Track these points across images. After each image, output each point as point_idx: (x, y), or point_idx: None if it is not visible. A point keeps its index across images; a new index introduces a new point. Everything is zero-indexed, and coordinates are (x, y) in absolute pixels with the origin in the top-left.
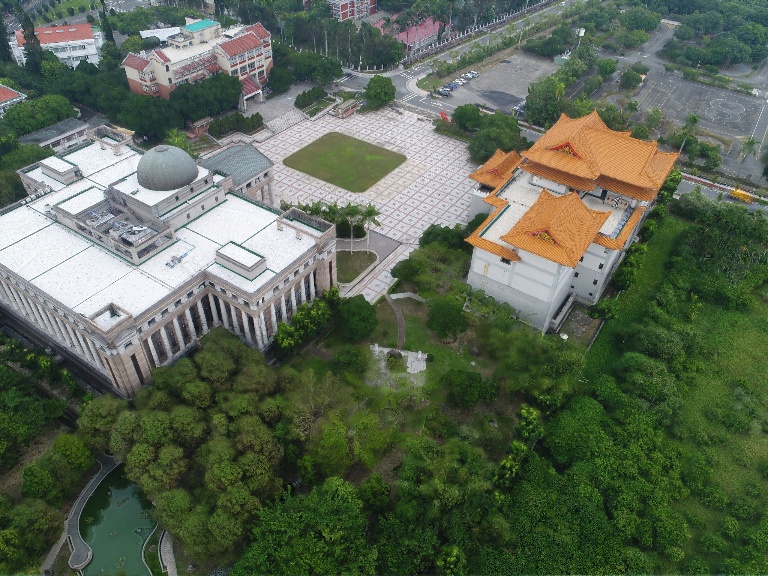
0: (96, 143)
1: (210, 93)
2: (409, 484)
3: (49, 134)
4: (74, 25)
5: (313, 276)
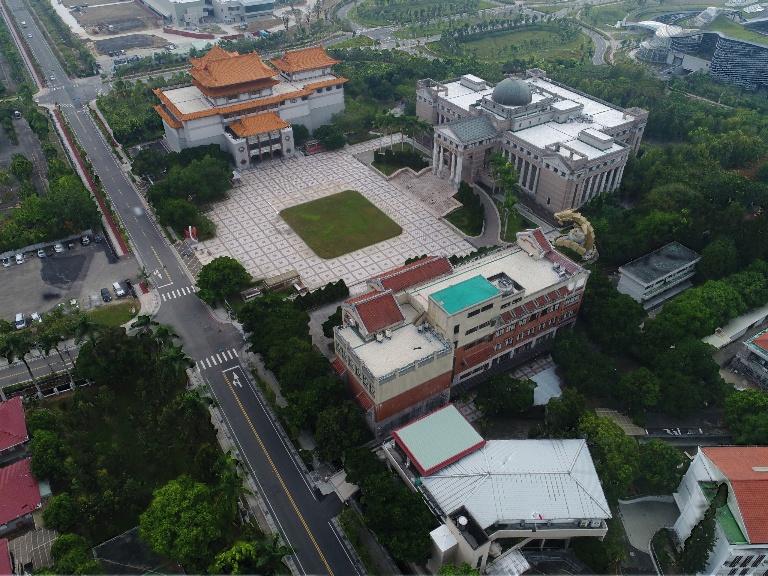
0: None
1: None
2: None
3: (661, 263)
4: (767, 479)
5: None
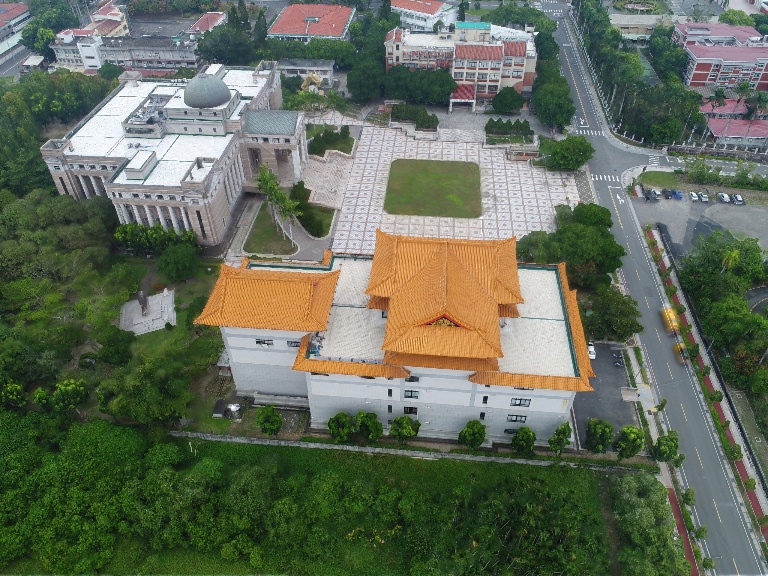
0: (264, 71)
1: (417, 81)
2: None
3: (306, 64)
4: None
5: (185, 213)
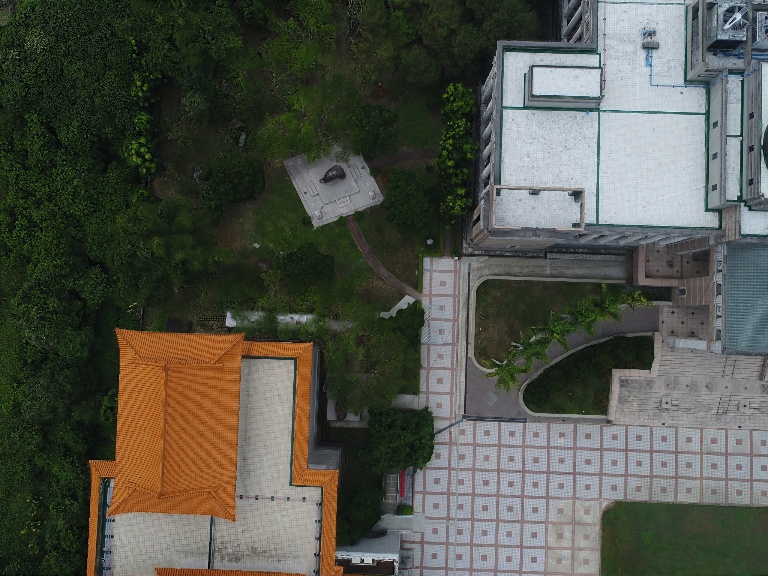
0: None
1: None
2: (217, 6)
3: None
4: None
5: None
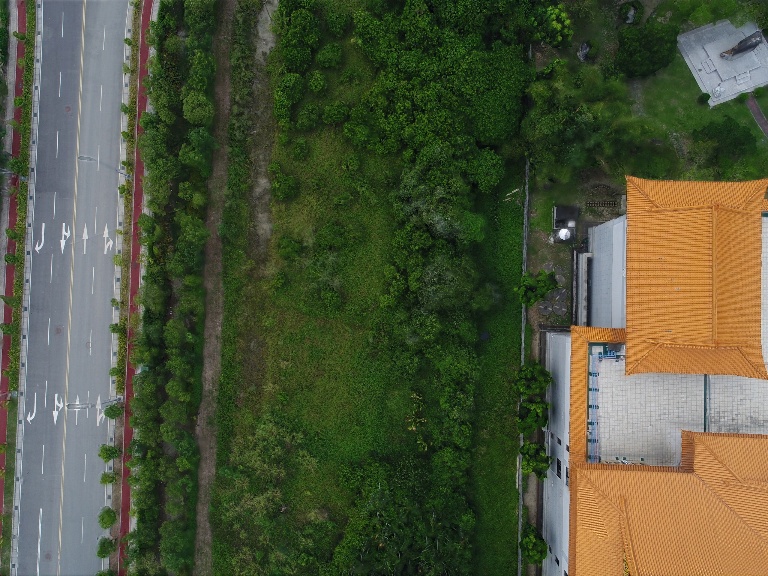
0: None
1: None
2: None
3: None
4: None
5: None
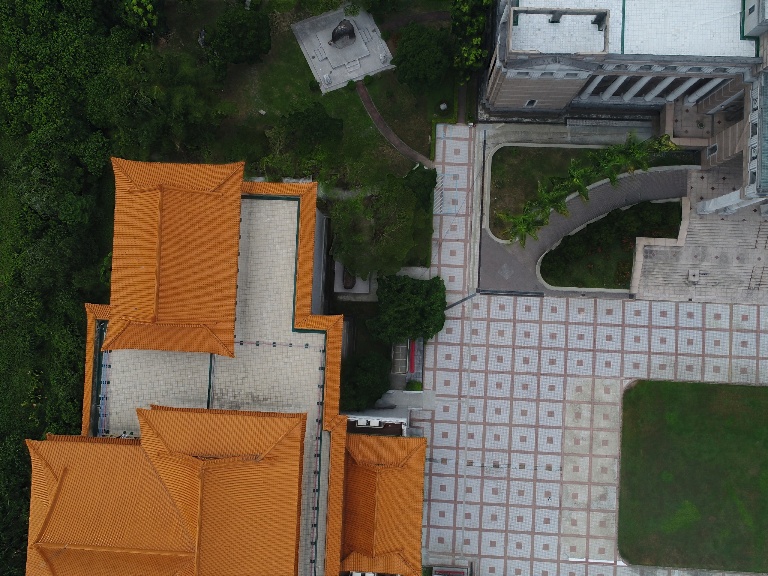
0: None
1: None
2: None
3: None
4: None
5: None
